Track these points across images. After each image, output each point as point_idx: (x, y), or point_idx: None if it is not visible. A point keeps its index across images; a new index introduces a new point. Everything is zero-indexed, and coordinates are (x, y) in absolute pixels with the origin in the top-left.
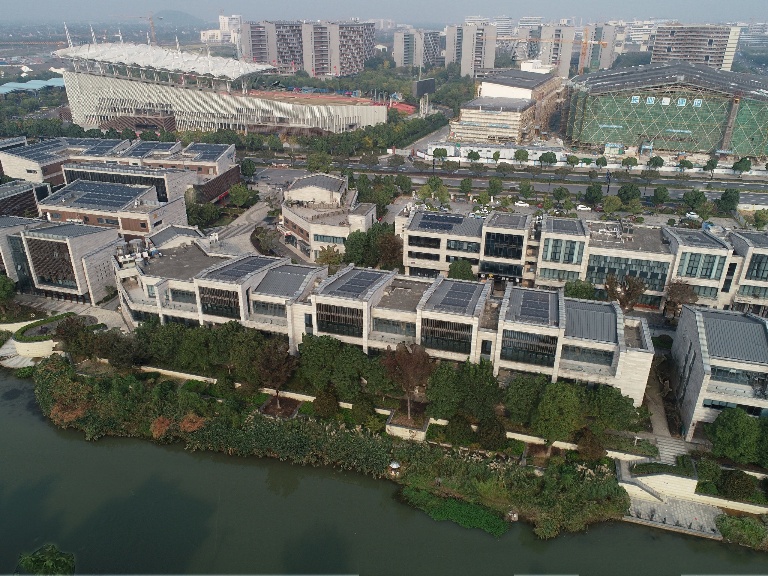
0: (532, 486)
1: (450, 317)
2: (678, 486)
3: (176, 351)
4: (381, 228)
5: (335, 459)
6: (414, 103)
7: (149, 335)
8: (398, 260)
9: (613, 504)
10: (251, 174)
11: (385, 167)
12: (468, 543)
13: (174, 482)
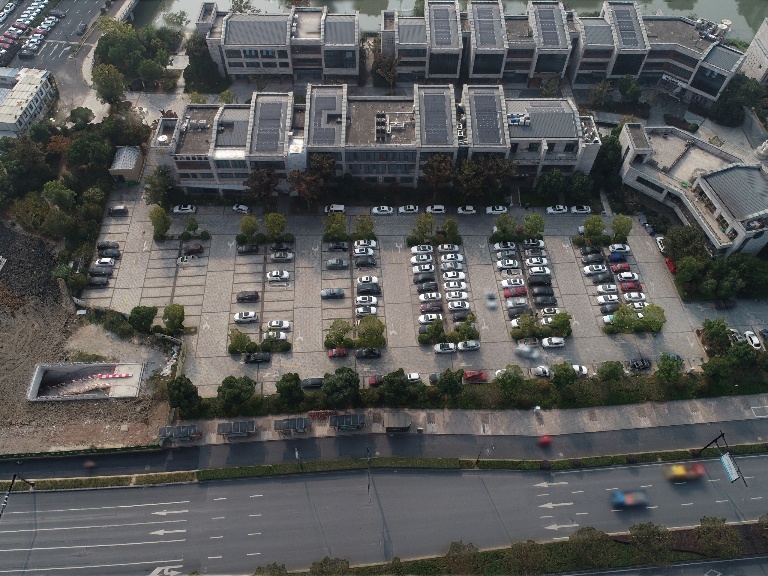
0: None
1: None
2: None
3: None
4: (608, 142)
5: None
6: None
7: None
8: None
9: None
10: None
11: None
12: None
13: None
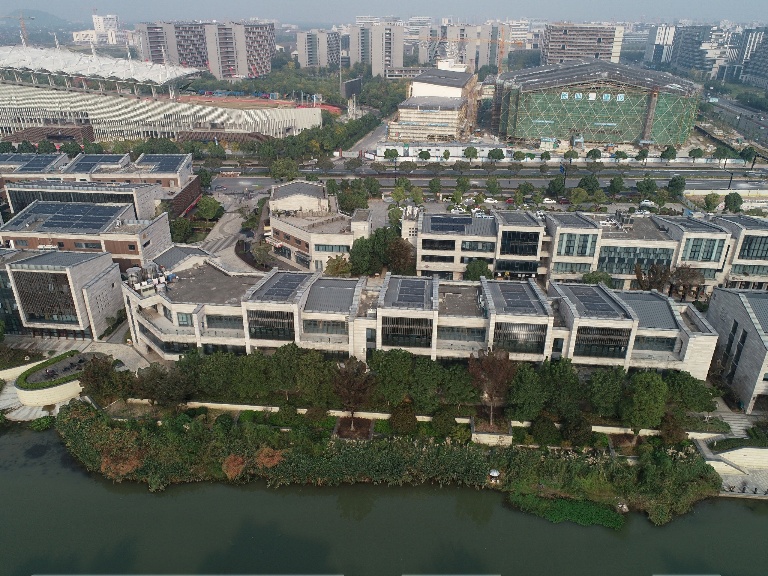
0: (632, 475)
1: (525, 319)
2: (756, 457)
3: (229, 382)
4: (383, 233)
5: (433, 475)
6: (337, 104)
7: (194, 367)
8: (410, 265)
9: (706, 482)
10: (208, 184)
11: (339, 170)
12: (594, 540)
13: (271, 524)
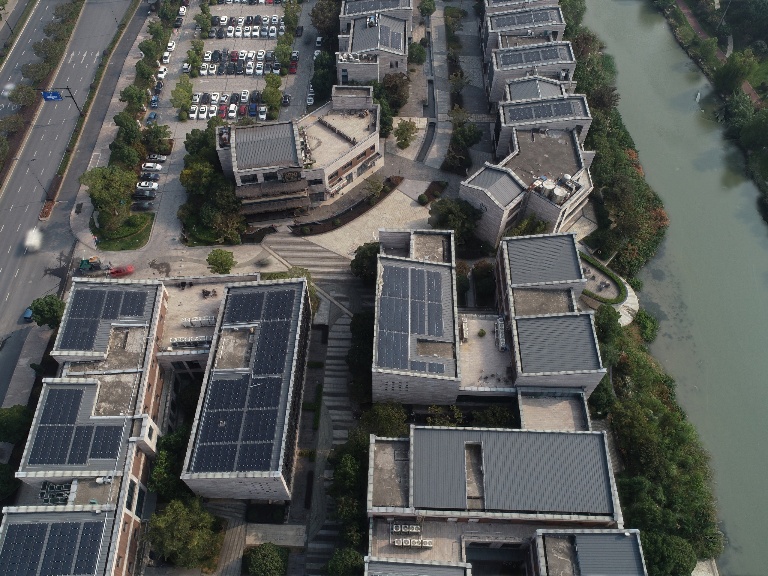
0: None
1: None
2: None
3: None
4: None
5: None
6: None
7: None
8: None
9: None
10: None
11: None
12: None
13: None
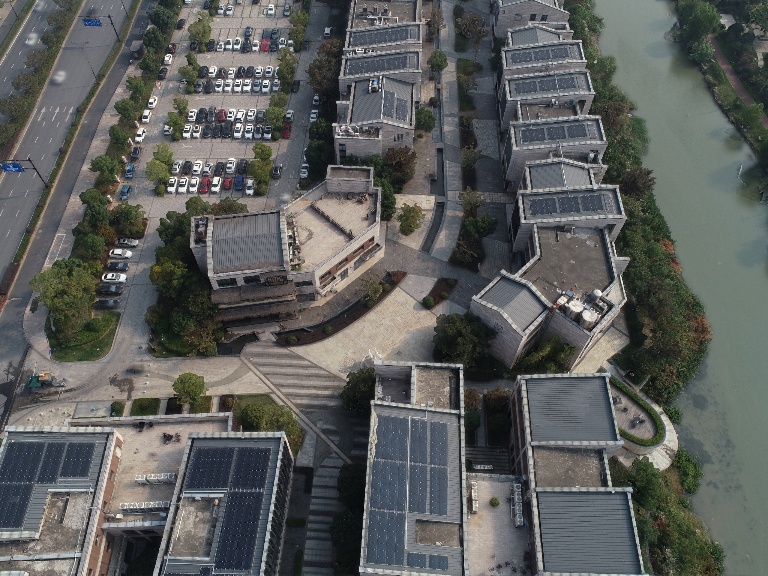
0: None
1: None
2: None
3: None
4: None
5: None
6: None
7: None
8: None
9: None
10: None
11: None
12: None
13: (699, 248)
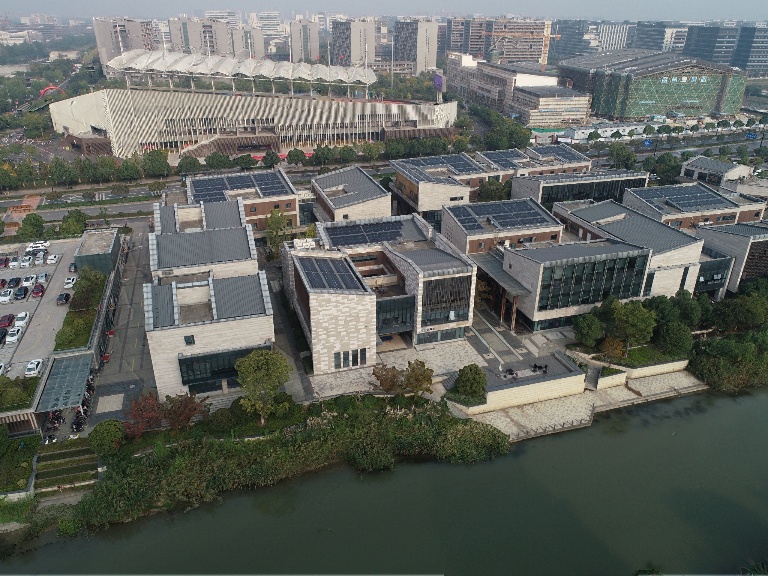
0: None
1: None
2: None
3: None
4: None
5: None
6: None
7: None
8: None
9: None
10: None
11: None
12: None
13: None
